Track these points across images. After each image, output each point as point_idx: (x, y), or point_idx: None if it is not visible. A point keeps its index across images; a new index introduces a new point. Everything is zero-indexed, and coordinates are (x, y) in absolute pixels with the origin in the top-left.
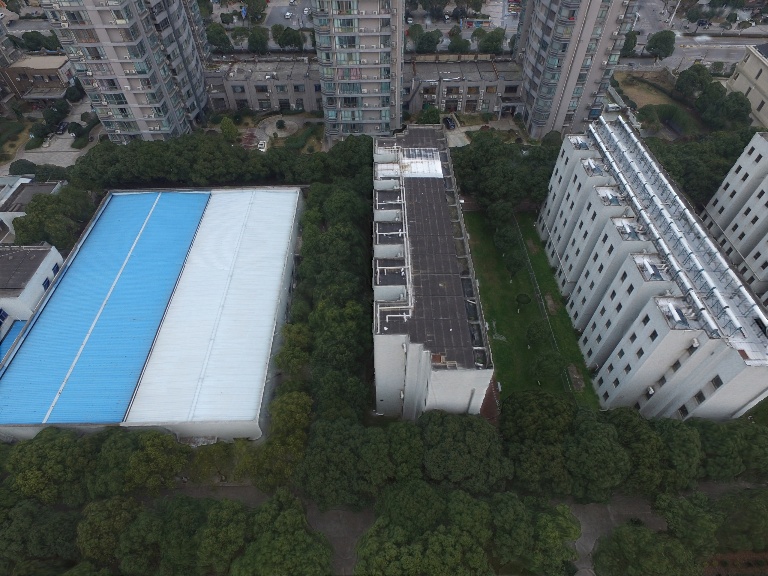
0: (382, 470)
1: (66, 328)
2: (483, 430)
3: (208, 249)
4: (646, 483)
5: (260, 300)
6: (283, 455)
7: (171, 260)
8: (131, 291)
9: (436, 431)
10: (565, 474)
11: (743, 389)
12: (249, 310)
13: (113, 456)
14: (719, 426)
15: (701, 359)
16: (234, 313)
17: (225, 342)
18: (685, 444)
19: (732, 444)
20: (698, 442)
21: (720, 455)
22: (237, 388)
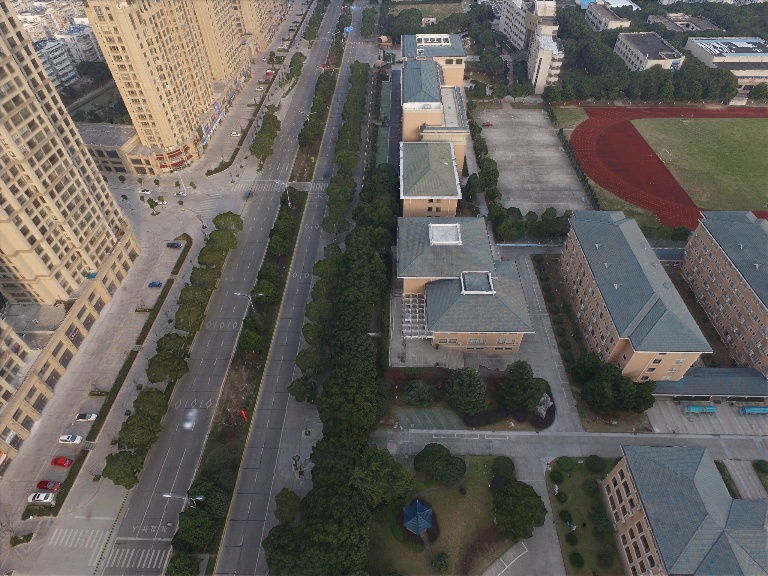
0: (671, 7)
1: None
2: None
3: None
4: None
5: None
6: (653, 6)
7: None
8: None
9: (680, 1)
10: None
11: None
12: (626, 3)
13: None
14: (726, 2)
15: None
16: (624, 3)
17: (626, 5)
18: (720, 3)
19: None
20: (722, 4)
21: (726, 5)
22: (634, 8)
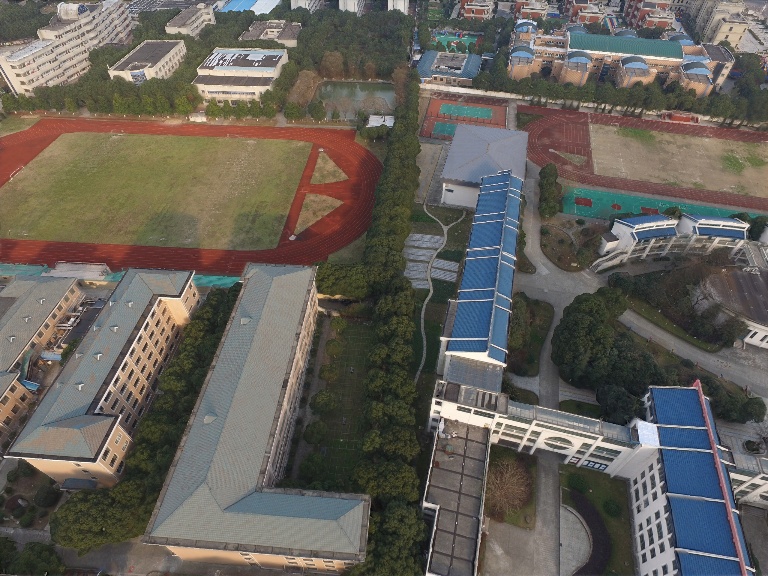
0: None
1: (231, 7)
2: (306, 8)
3: (261, 1)
4: (331, 16)
5: (272, 6)
6: (273, 12)
7: (252, 2)
8: (244, 4)
9: (298, 7)
10: (319, 16)
11: (351, 4)
12: None
13: (245, 10)
14: None
15: (346, 1)
16: None
17: (264, 9)
18: None
19: (346, 11)
20: None
21: None
22: None
